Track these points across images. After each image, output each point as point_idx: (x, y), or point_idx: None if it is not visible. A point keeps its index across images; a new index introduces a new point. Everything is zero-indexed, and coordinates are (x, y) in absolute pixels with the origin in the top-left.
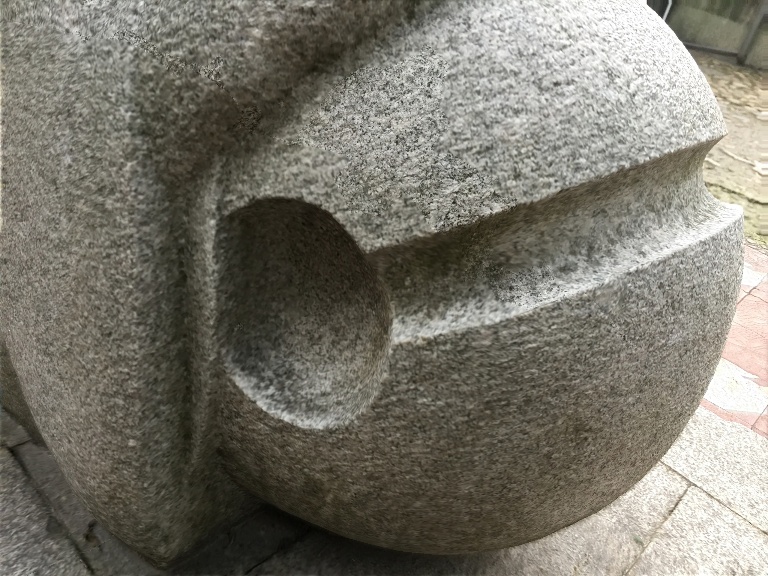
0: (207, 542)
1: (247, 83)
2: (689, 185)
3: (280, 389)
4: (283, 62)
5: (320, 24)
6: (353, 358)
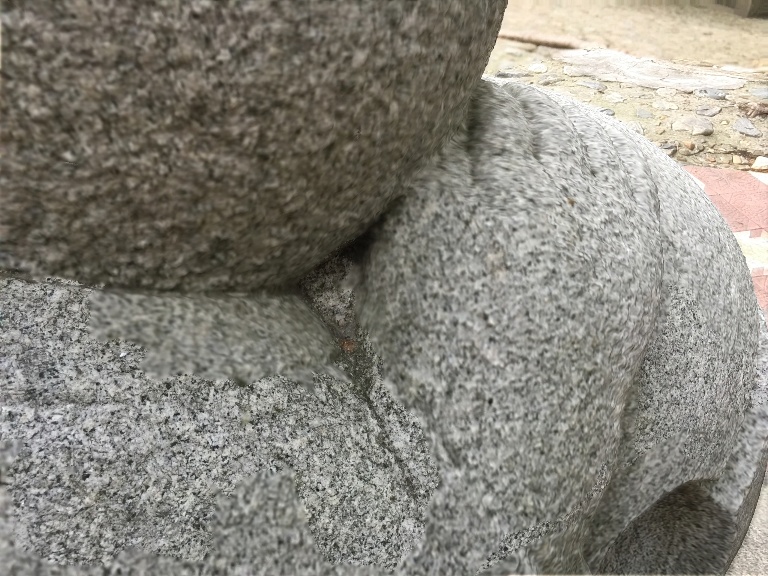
0: None
1: None
2: None
3: None
4: None
5: None
6: (641, 544)
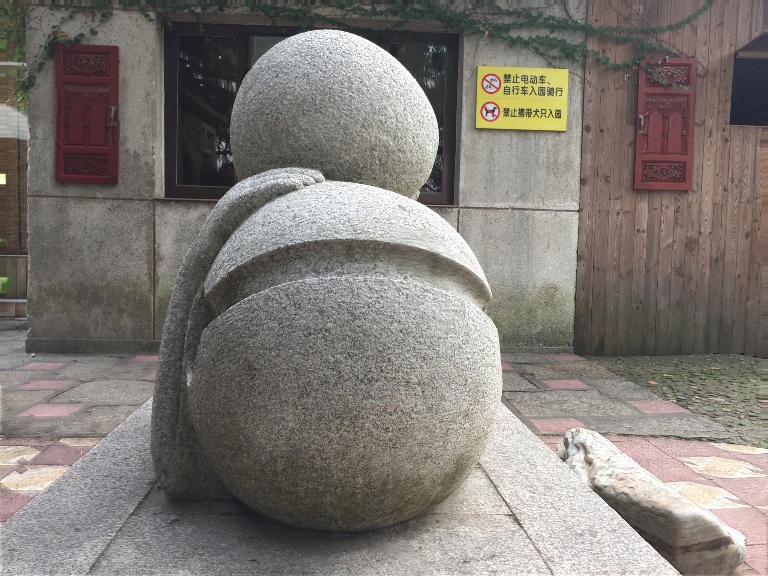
0: (195, 500)
1: (204, 249)
2: (360, 267)
3: None
4: (214, 240)
5: (219, 224)
6: None
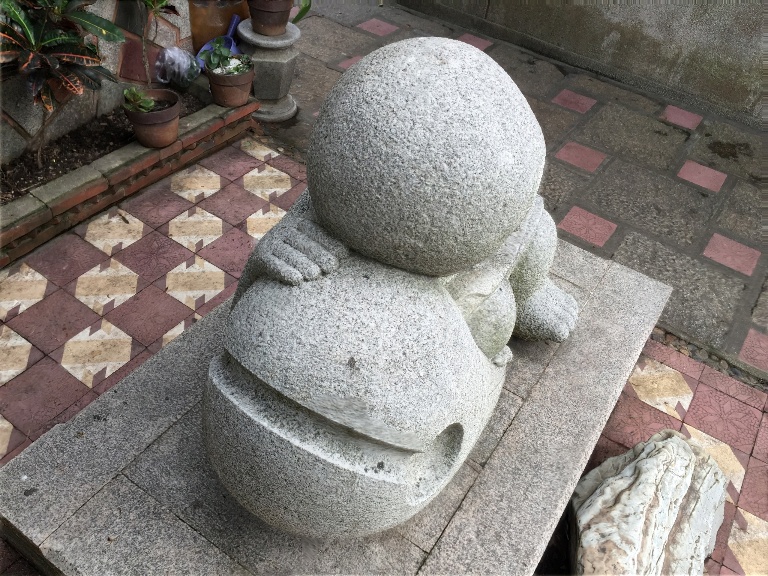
0: None
1: None
2: (285, 408)
3: None
4: None
5: None
6: None
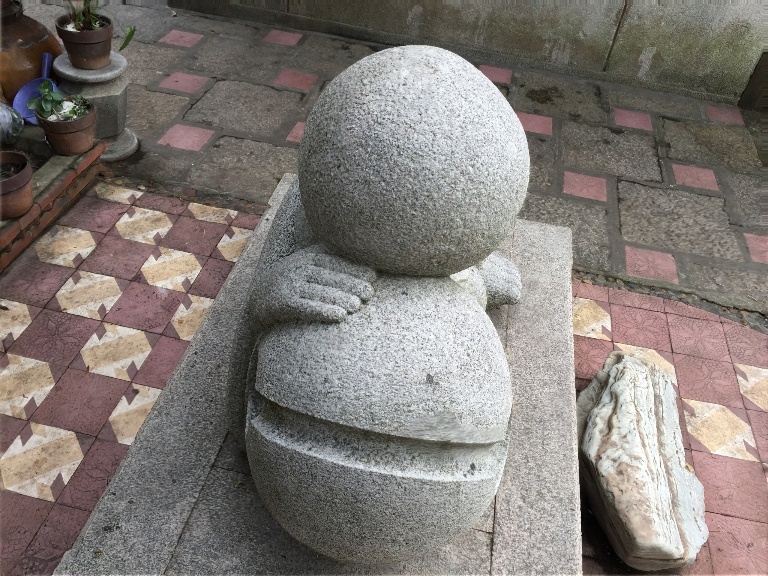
0: None
1: (261, 317)
2: (373, 445)
3: (256, 415)
4: None
5: None
6: None
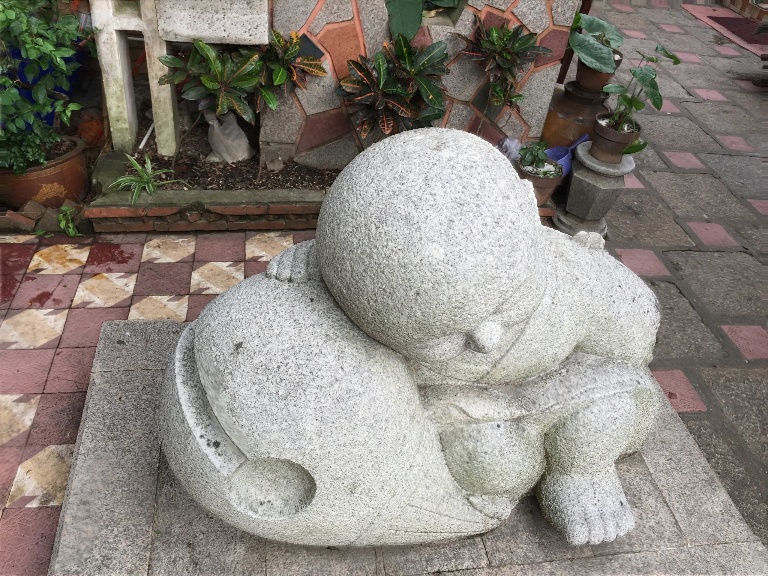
0: None
1: None
2: None
3: None
4: None
5: None
6: None
